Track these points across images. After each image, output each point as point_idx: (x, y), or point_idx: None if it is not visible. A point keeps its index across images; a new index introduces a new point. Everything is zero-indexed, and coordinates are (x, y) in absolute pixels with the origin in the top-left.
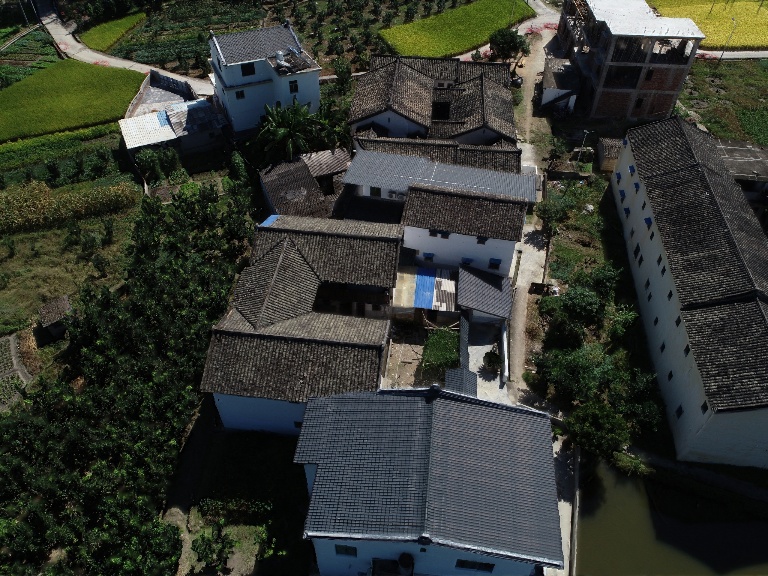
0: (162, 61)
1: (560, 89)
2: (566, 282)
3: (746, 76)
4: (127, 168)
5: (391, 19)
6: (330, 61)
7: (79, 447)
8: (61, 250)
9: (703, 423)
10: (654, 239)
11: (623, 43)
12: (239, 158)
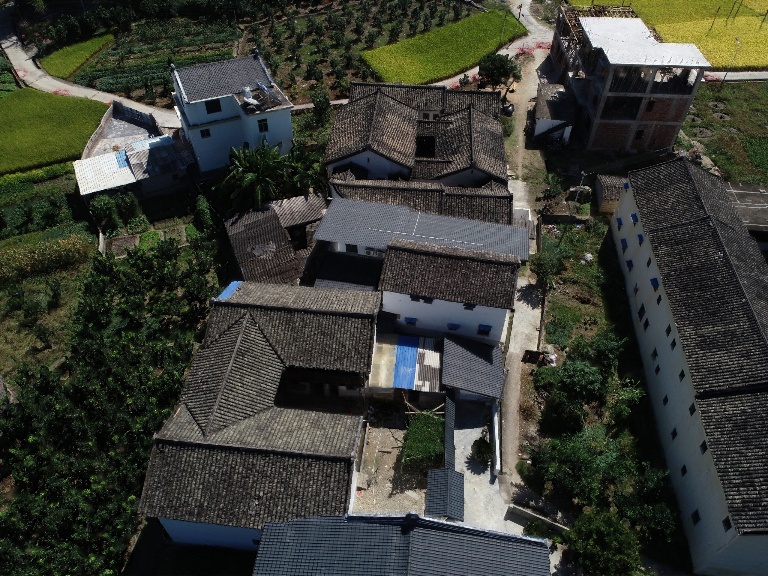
0: (127, 89)
1: (554, 119)
2: (564, 348)
3: (751, 100)
4: (82, 215)
5: (374, 39)
6: (308, 87)
7: (3, 571)
8: (1, 316)
9: (725, 542)
10: (662, 304)
11: (622, 72)
12: (204, 204)
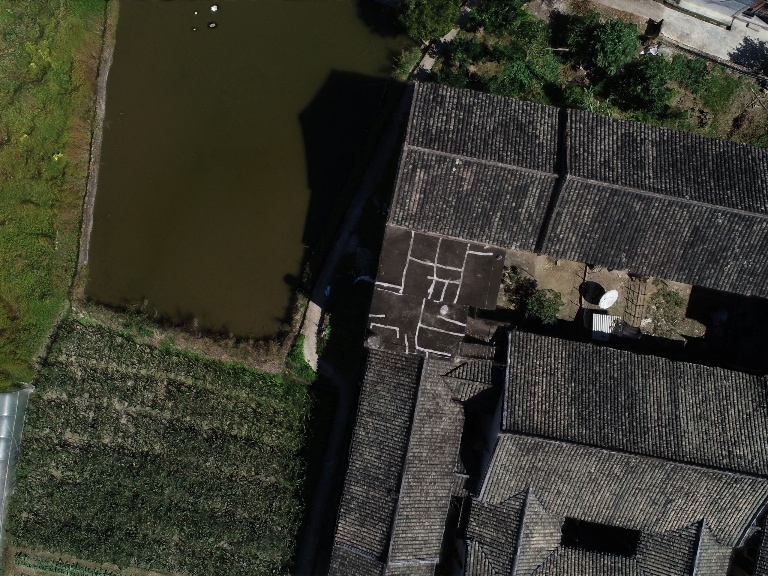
0: None
1: None
2: None
3: None
4: None
5: None
6: None
7: None
8: None
9: None
10: None
11: None
12: None
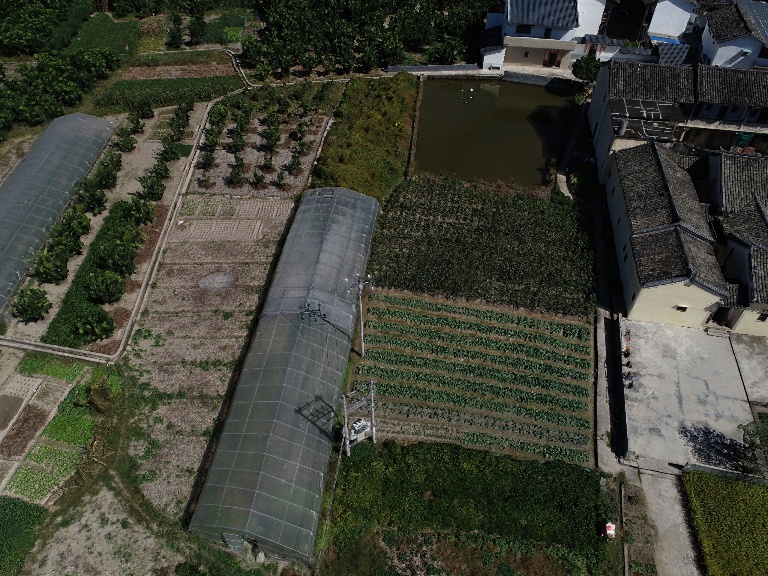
0: None
1: None
2: None
3: None
4: None
5: None
6: None
7: None
8: None
9: None
10: None
11: None
12: None
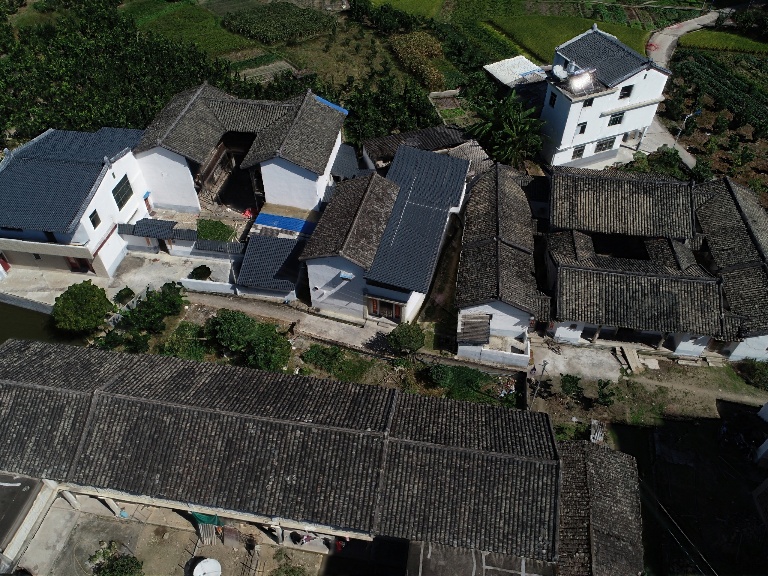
0: (674, 73)
1: None
2: (302, 357)
3: None
4: None
5: None
6: None
7: None
8: None
9: None
10: None
11: None
12: None
